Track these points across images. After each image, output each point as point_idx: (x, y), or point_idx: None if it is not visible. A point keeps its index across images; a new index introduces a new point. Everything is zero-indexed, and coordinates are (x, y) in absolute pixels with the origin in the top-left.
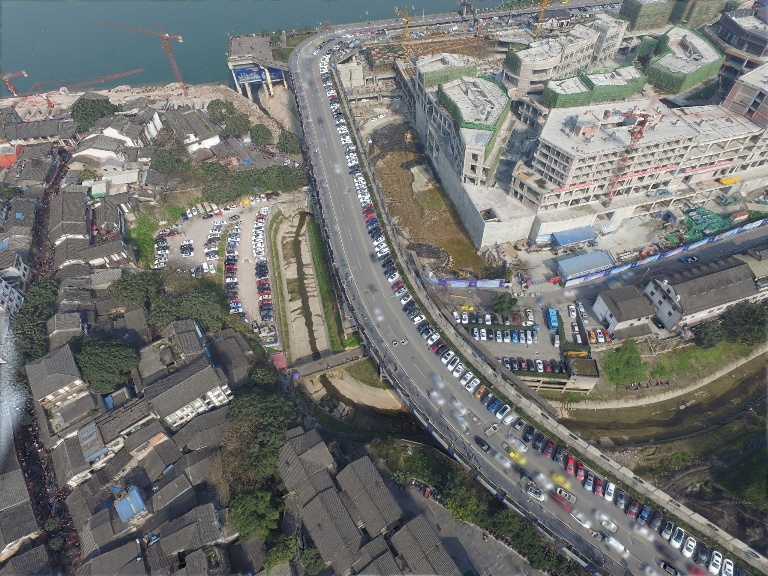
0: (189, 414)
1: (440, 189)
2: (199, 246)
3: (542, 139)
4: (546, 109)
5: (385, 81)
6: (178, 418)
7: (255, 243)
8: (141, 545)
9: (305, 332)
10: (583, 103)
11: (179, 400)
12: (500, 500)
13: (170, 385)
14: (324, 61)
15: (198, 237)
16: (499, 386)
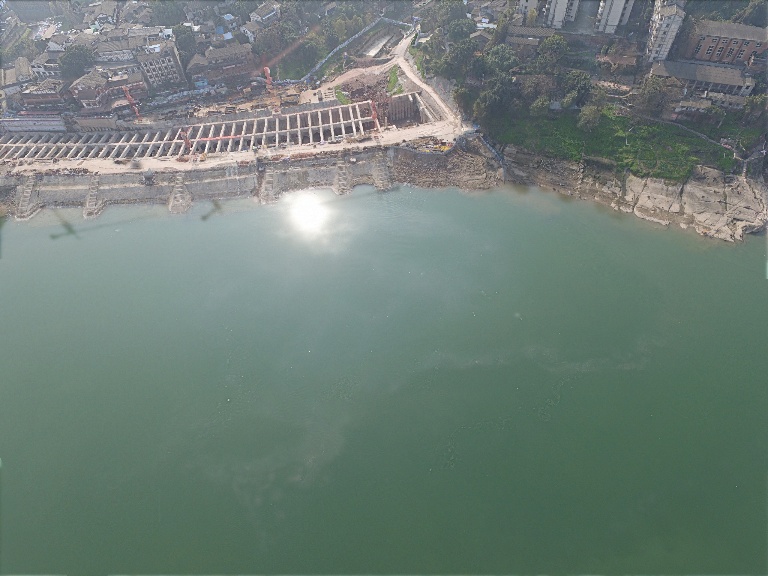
0: None
1: None
2: None
3: None
4: None
5: None
6: None
7: None
8: None
9: None
10: None
11: None
12: None
13: None
14: None
15: None
16: None
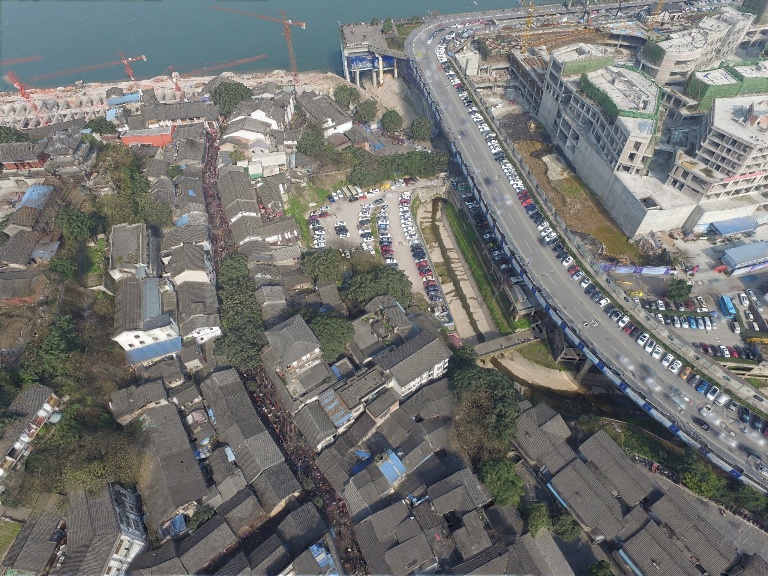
0: (415, 385)
1: (576, 178)
2: (352, 228)
3: (716, 128)
4: (691, 100)
5: (498, 71)
6: (409, 388)
7: (405, 226)
8: (406, 505)
9: (464, 314)
10: (731, 94)
11: (415, 370)
12: (734, 477)
13: (403, 355)
14: (441, 50)
15: (349, 219)
16: (702, 368)
